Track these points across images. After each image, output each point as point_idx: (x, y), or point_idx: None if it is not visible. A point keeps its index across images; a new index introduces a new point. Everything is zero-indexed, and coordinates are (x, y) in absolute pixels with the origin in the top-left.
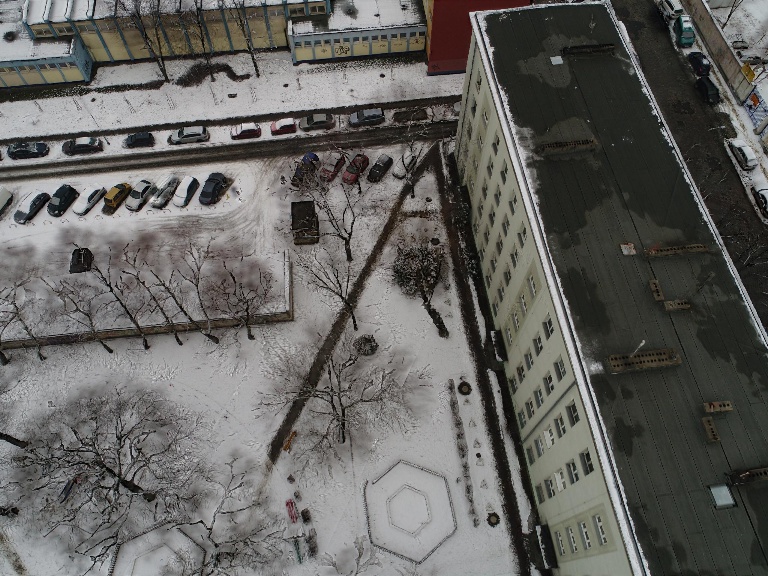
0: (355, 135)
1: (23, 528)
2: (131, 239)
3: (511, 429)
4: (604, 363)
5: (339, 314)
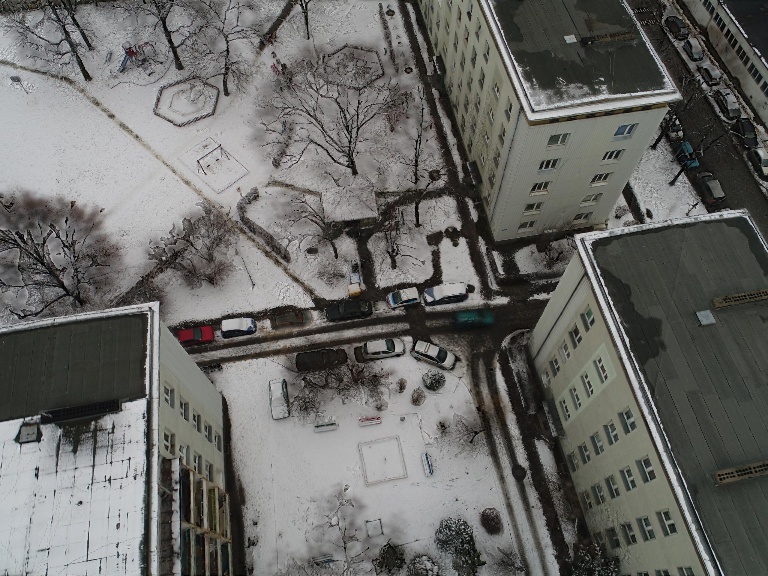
0: None
1: (96, 86)
2: None
3: (421, 29)
4: None
5: None
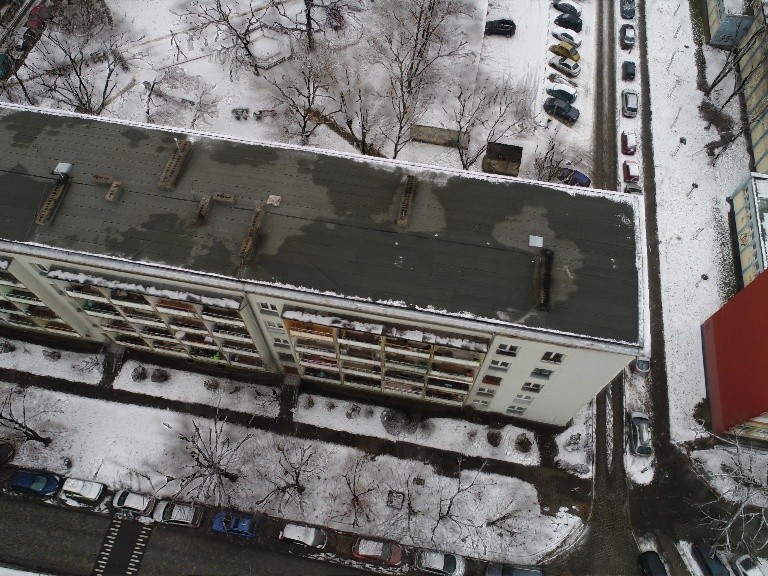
0: None
1: None
2: (521, 59)
3: None
4: None
5: None
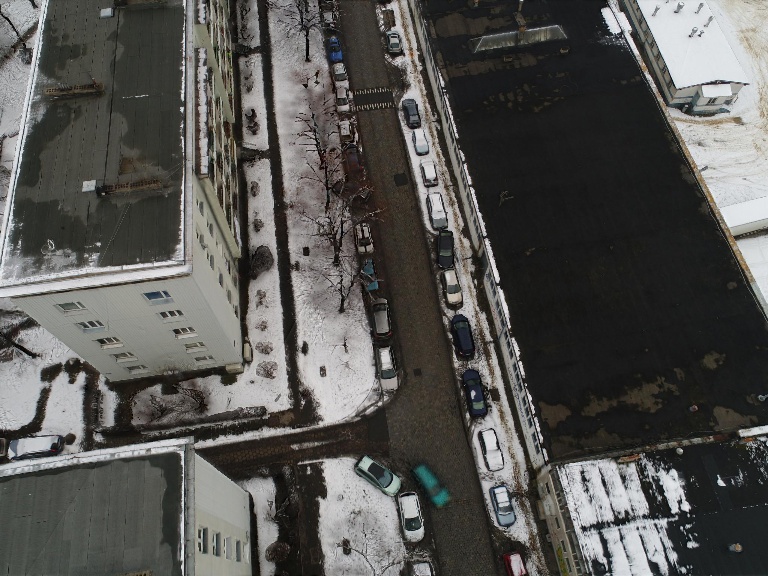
0: None
1: None
2: None
3: None
4: None
5: (17, 41)
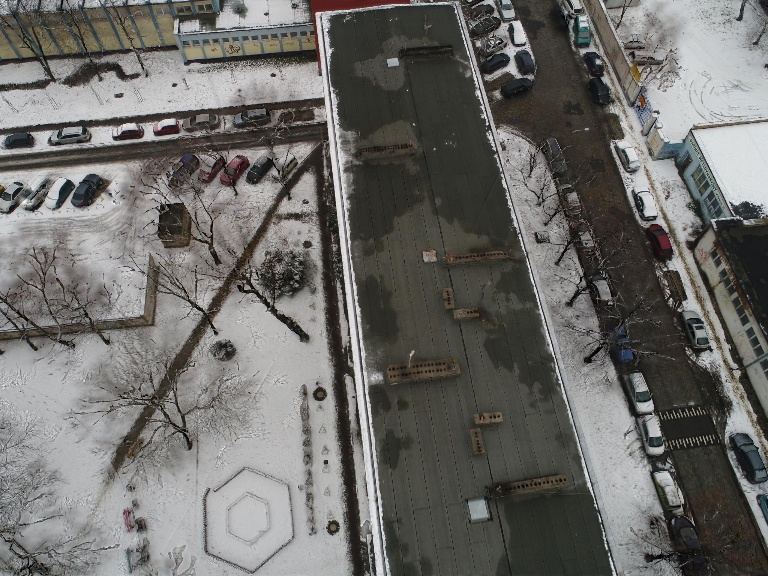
0: (239, 136)
1: None
2: None
3: None
4: (385, 373)
5: (201, 318)
